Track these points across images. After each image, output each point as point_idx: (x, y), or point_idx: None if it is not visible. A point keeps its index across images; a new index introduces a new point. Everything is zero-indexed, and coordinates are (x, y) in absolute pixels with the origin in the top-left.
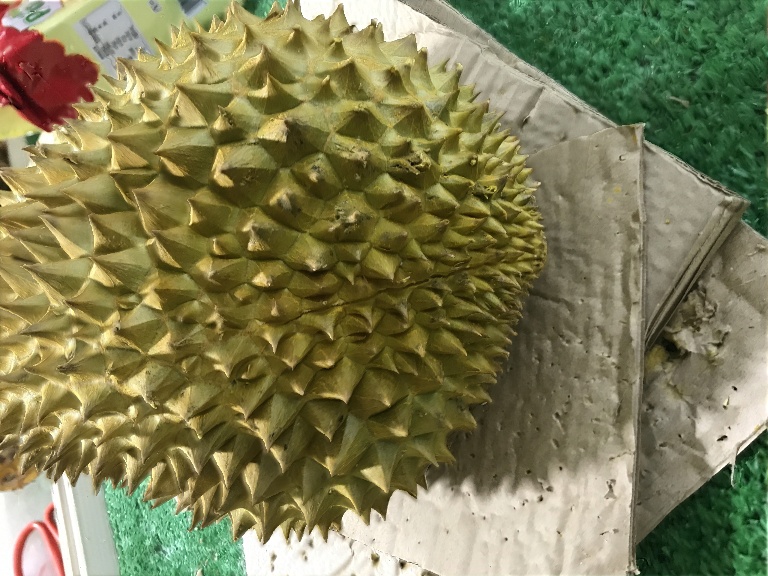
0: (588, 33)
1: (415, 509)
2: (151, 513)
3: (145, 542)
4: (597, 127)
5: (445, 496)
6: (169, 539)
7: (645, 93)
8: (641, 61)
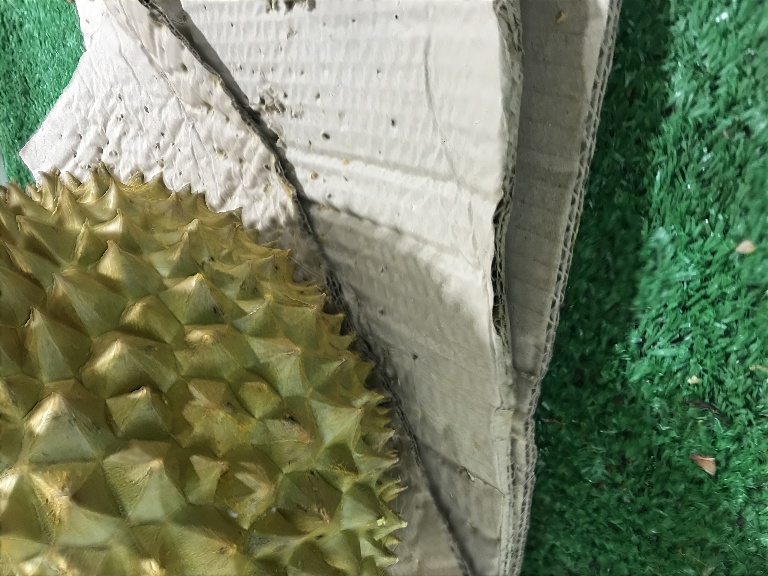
0: (603, 500)
1: None
2: (19, 46)
3: (11, 73)
4: (492, 571)
5: None
6: (38, 94)
7: (564, 575)
8: (595, 565)
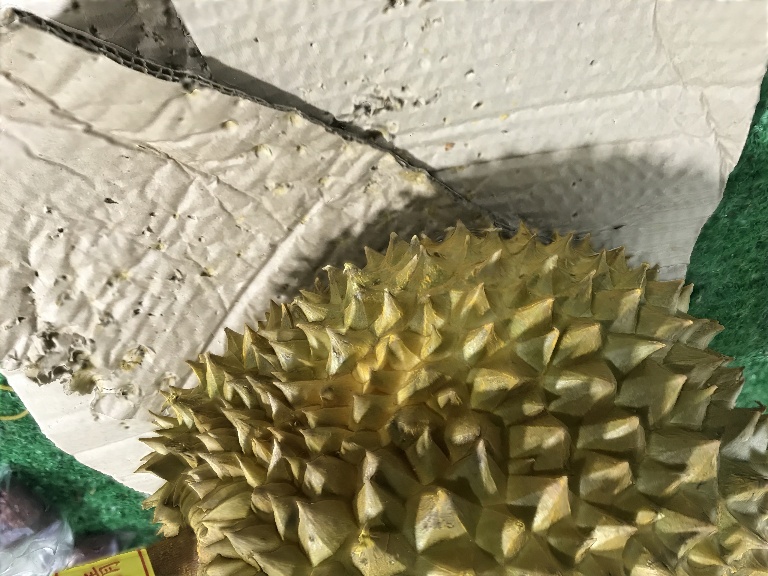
0: None
1: None
2: None
3: None
4: None
5: None
6: None
7: None
8: (720, 259)
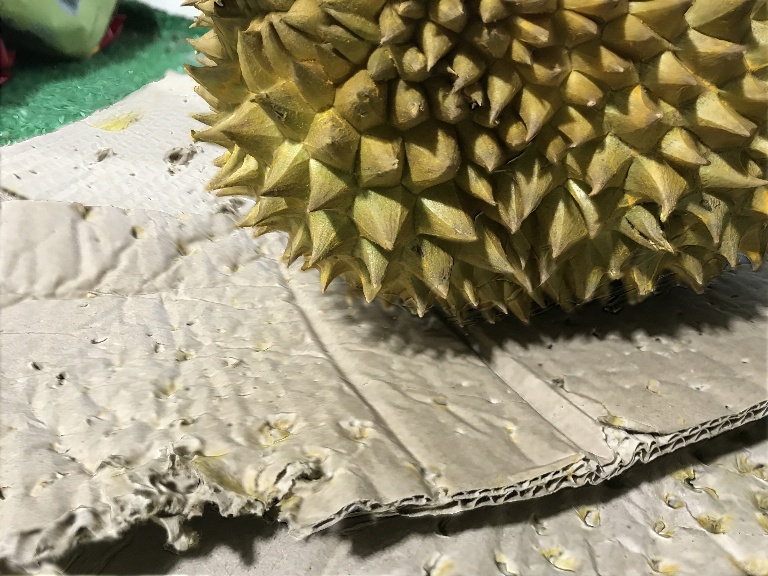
0: None
1: (740, 349)
2: None
3: None
4: None
5: (756, 325)
6: None
7: None
8: None
